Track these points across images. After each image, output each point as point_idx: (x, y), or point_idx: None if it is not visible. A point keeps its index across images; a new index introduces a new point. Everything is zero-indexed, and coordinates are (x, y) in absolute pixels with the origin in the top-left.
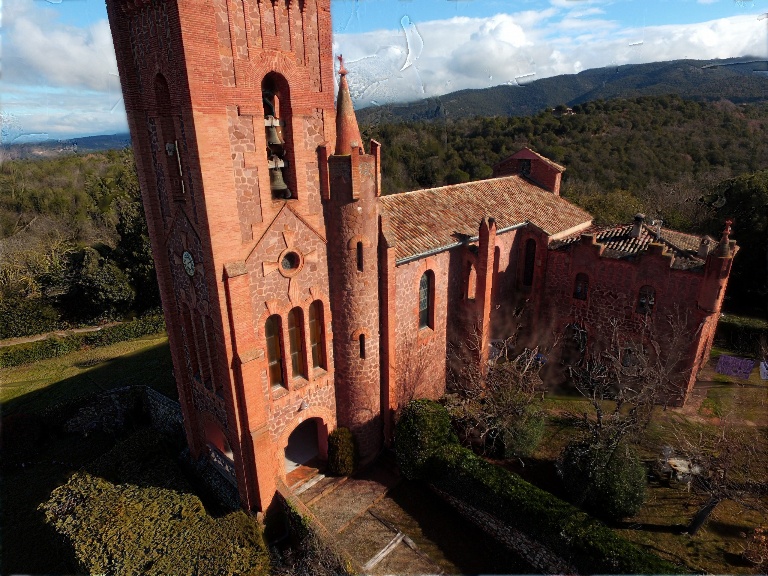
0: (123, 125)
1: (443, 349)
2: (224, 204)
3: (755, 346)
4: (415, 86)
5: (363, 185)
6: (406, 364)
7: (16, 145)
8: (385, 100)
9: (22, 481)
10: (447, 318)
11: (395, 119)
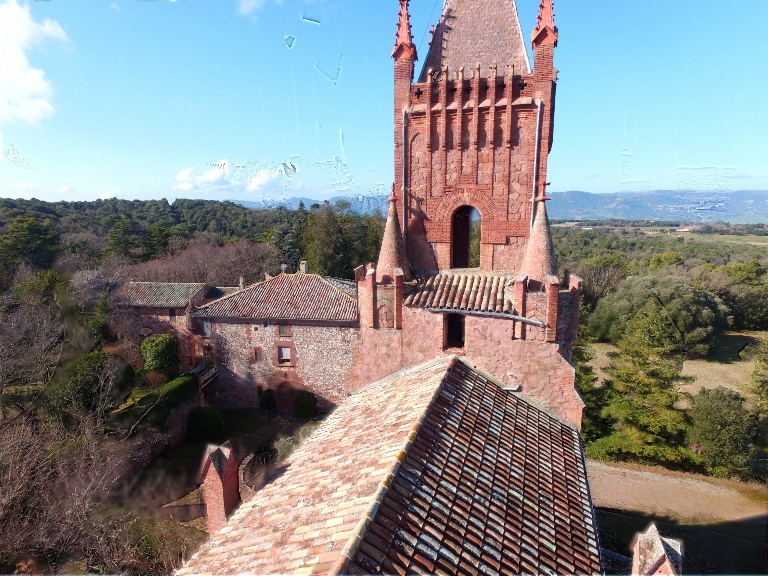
0: None
1: None
2: None
3: None
4: None
5: None
6: None
7: None
8: None
9: (721, 568)
10: None
11: None
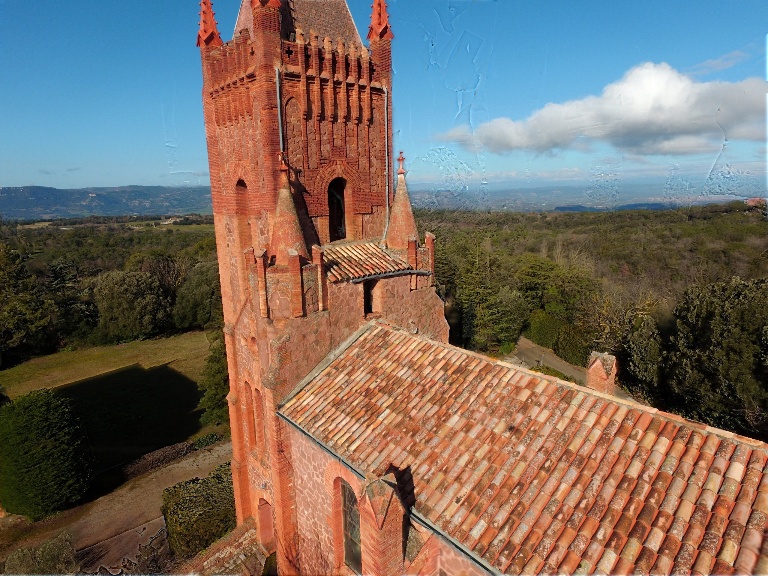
0: None
1: None
2: None
3: None
4: None
5: None
6: None
7: (698, 205)
8: None
9: None
10: None
11: None
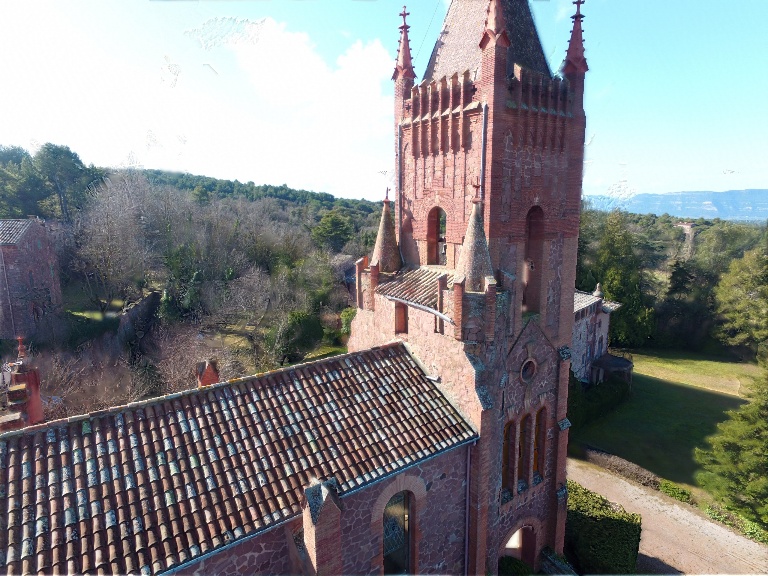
0: None
1: None
2: None
3: None
4: None
5: None
6: None
7: None
8: None
9: None
10: None
11: None
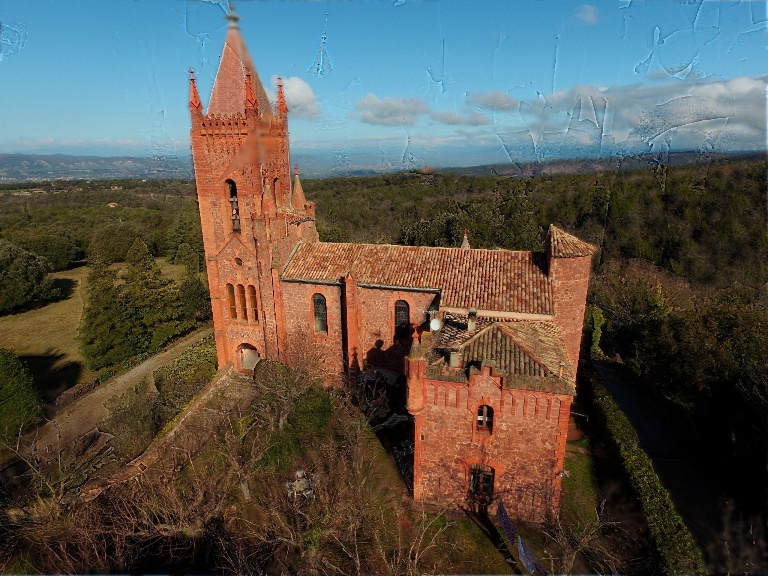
0: (503, 163)
1: (340, 354)
2: (209, 231)
3: (647, 573)
4: (766, 124)
5: (259, 233)
6: (303, 346)
7: (400, 179)
8: (718, 142)
9: None
10: (343, 334)
11: (735, 165)
